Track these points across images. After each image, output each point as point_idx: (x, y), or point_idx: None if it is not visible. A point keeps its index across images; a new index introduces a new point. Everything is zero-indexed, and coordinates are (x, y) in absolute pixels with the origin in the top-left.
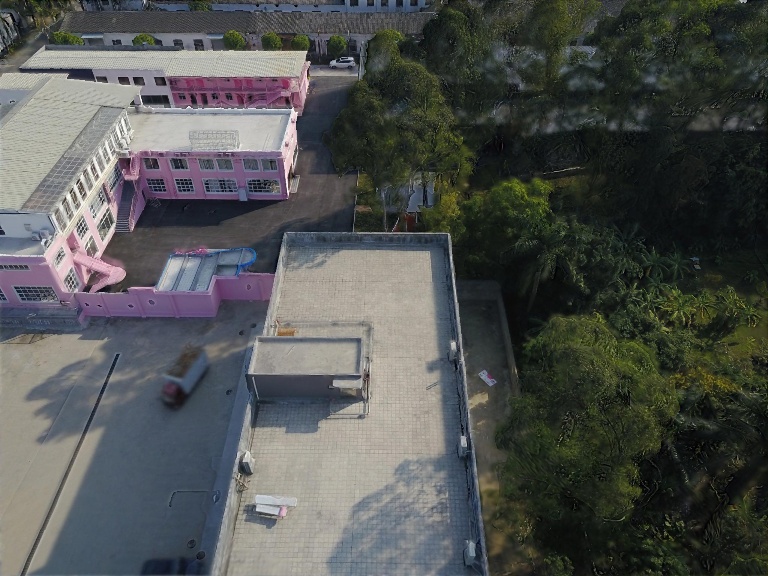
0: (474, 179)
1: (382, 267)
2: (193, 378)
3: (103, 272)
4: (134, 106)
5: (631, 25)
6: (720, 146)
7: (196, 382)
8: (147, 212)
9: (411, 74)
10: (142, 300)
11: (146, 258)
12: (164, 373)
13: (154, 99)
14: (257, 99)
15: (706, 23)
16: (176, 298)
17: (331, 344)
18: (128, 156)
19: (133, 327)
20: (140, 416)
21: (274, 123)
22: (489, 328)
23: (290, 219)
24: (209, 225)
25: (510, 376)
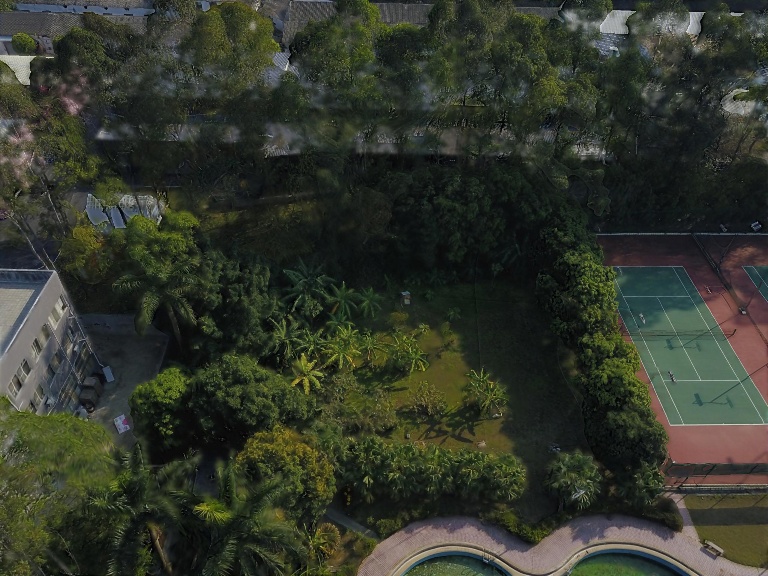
0: None
1: None
2: None
3: None
4: None
5: (301, 48)
6: (408, 178)
7: None
8: None
9: None
10: None
11: None
12: None
13: None
14: None
15: (379, 48)
16: None
17: None
18: None
19: None
20: None
21: None
22: (152, 367)
23: None
24: None
25: None
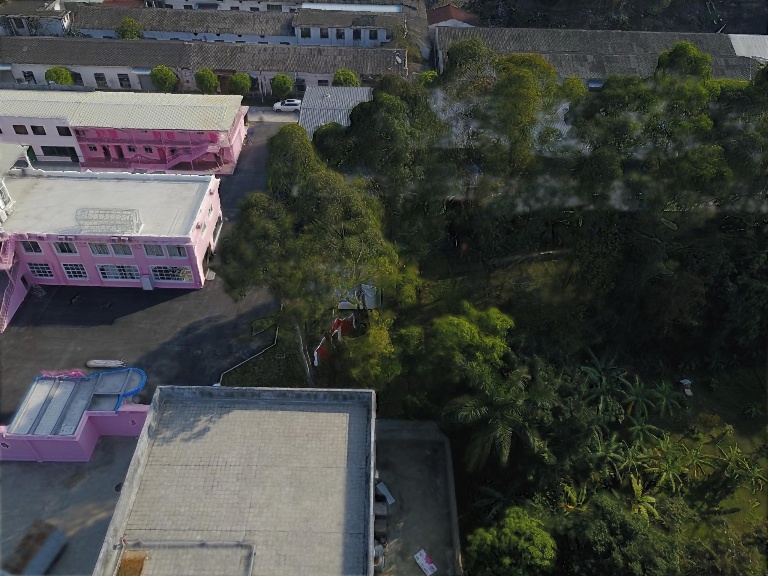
0: (428, 264)
1: (282, 441)
2: (44, 560)
3: None
4: (21, 168)
5: (614, 110)
6: (720, 257)
7: (46, 568)
8: (27, 304)
9: (321, 191)
10: None
11: (13, 372)
12: (7, 551)
13: (58, 150)
14: (180, 153)
15: (707, 110)
16: (34, 443)
17: None
18: None
19: None
20: None
21: (189, 194)
22: (432, 483)
23: (201, 317)
24: (101, 324)
25: (454, 561)
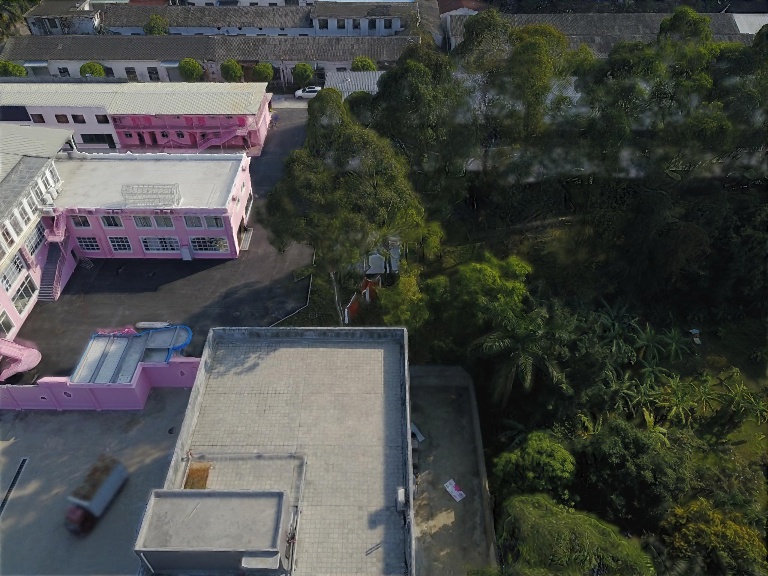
0: (447, 232)
1: (325, 372)
2: (109, 492)
3: (14, 357)
4: (66, 152)
5: (620, 73)
6: (723, 209)
7: (112, 498)
8: (77, 275)
9: (356, 144)
10: (55, 393)
11: (69, 334)
12: (76, 485)
13: (97, 138)
14: (211, 138)
15: (707, 71)
16: (94, 391)
17: (246, 500)
18: (52, 214)
19: (46, 423)
20: (41, 545)
21: (223, 171)
22: (459, 423)
23: (238, 283)
24: (146, 291)
25: (481, 488)
